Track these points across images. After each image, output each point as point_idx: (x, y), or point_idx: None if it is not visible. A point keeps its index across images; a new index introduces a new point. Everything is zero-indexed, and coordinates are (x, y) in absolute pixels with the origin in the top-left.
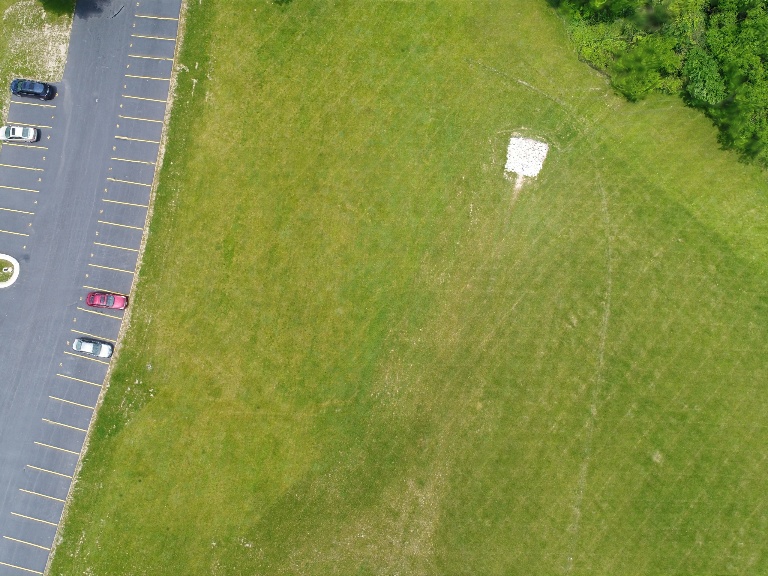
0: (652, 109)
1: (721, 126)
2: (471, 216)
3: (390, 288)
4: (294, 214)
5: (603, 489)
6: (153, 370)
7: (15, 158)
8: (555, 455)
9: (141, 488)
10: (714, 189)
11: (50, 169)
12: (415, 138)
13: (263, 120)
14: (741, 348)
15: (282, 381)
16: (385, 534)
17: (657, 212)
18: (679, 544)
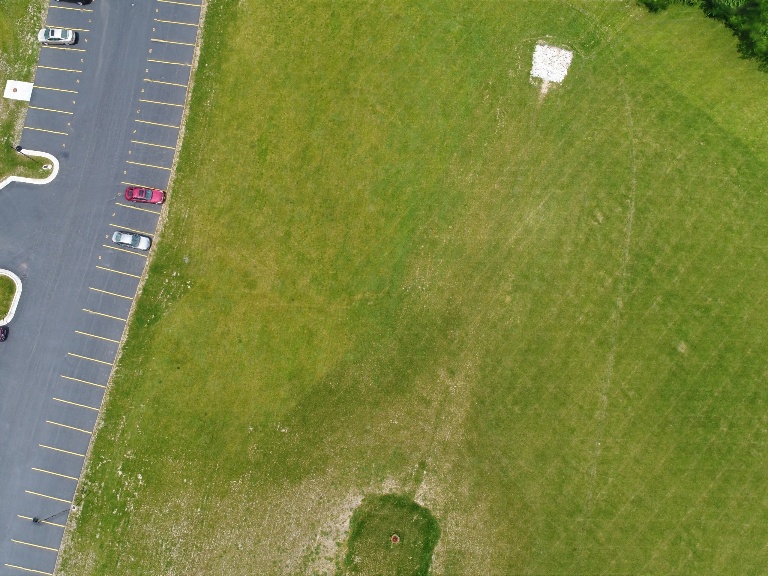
0: (673, 19)
1: (741, 35)
2: (498, 119)
3: (420, 187)
4: (326, 115)
5: (630, 378)
6: (190, 263)
7: (54, 60)
8: (582, 345)
9: (180, 375)
10: (734, 96)
11: (88, 71)
12: (443, 44)
13: (295, 25)
14: (763, 245)
15: (316, 274)
16: (417, 421)
17: (679, 117)
18: (704, 430)
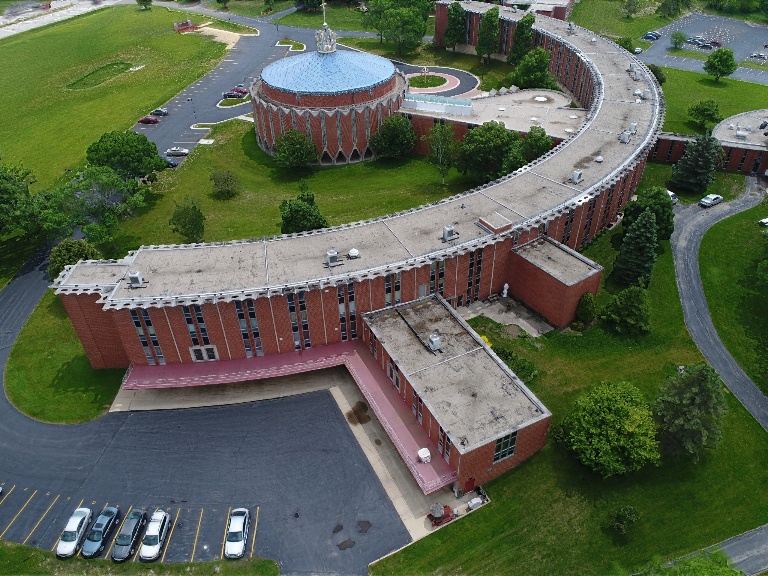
0: None
1: None
2: None
3: None
4: None
5: None
6: None
7: None
8: None
9: None
10: None
11: None
12: None
13: None
14: None
15: None
16: None
17: None
18: None
